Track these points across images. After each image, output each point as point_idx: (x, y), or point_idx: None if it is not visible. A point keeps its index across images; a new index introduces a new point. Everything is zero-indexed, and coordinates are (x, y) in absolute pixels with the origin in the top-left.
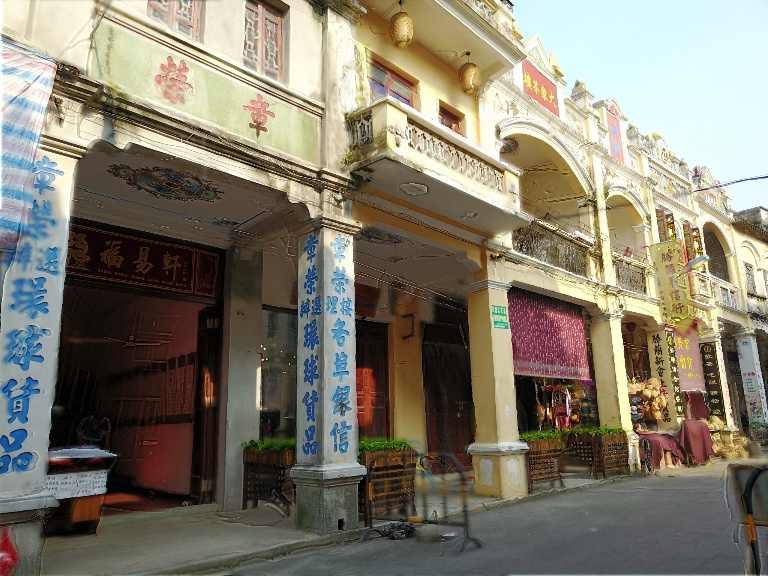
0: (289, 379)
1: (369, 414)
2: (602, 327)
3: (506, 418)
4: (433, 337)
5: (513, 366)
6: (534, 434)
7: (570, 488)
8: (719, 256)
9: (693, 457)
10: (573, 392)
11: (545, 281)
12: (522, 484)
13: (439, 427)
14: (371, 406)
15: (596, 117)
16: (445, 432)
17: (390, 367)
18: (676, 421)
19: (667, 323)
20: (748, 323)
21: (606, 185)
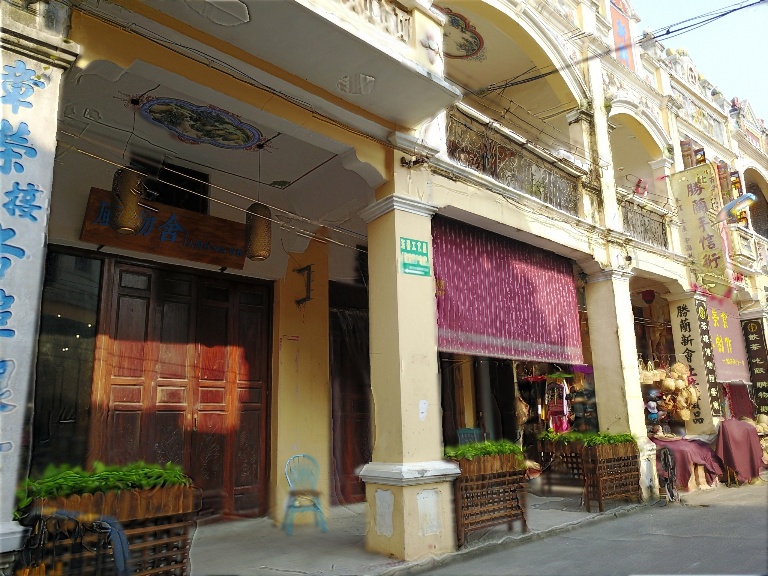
0: (75, 360)
1: (235, 415)
2: (601, 289)
3: (420, 422)
4: (342, 301)
5: (437, 336)
6: (476, 447)
7: (539, 532)
8: (764, 215)
9: (736, 473)
10: (572, 384)
11: (506, 213)
12: (446, 533)
13: (361, 433)
14: (239, 403)
15: (593, 4)
16: (370, 440)
17: (274, 345)
18: (711, 422)
19: (697, 289)
20: None
21: (608, 97)
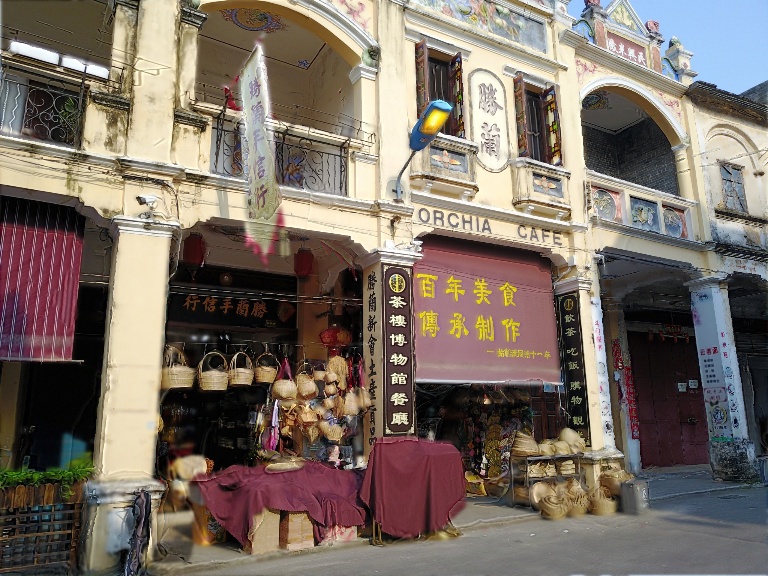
0: None
1: None
2: (115, 249)
3: None
4: None
5: None
6: None
7: None
8: (668, 153)
9: (378, 524)
10: None
11: None
12: None
13: None
14: None
15: None
16: None
17: None
18: None
19: (381, 248)
20: (708, 261)
21: None
